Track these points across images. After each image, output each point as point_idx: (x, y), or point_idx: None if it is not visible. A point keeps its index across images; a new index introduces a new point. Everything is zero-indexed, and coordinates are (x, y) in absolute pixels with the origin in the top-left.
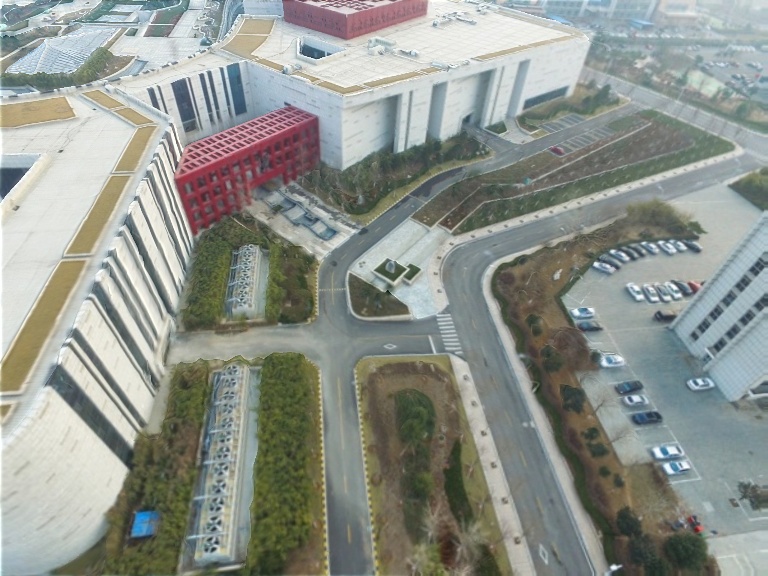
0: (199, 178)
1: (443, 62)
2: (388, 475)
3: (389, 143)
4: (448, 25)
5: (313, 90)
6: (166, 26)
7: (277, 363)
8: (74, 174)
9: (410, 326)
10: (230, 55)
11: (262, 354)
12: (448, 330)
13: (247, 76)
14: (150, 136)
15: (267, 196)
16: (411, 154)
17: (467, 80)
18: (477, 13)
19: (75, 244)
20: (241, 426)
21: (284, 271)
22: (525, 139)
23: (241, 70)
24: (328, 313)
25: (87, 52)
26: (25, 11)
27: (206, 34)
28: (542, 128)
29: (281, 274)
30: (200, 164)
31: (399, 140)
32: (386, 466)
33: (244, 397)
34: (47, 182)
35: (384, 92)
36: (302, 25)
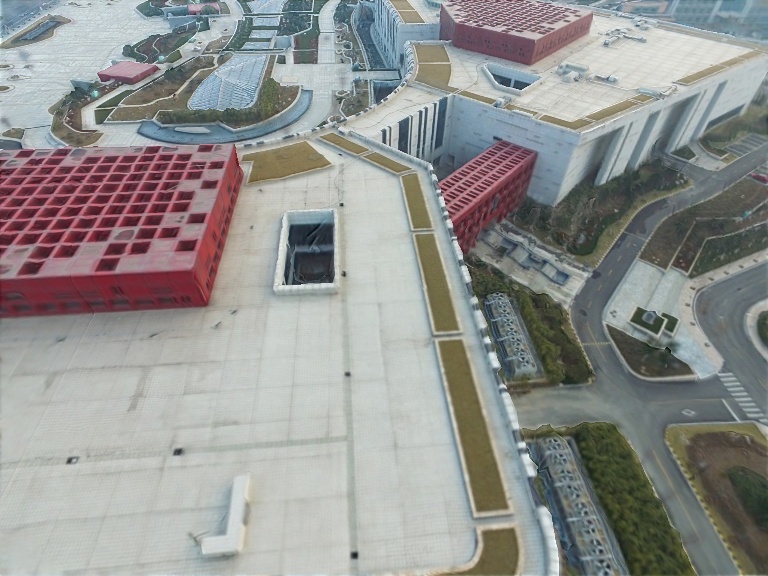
0: (454, 226)
1: (653, 89)
2: (767, 575)
3: (591, 175)
4: (620, 44)
5: (540, 126)
6: (310, 51)
7: (597, 436)
8: (373, 232)
9: (697, 388)
10: (428, 87)
11: (559, 420)
12: (739, 392)
13: (451, 109)
14: (420, 186)
15: (486, 236)
16: (614, 186)
17: (672, 106)
18: (637, 29)
19: (437, 319)
20: (597, 513)
21: (547, 324)
22: (718, 165)
23: (448, 104)
24: (605, 372)
25: (253, 83)
26: (170, 41)
27: (353, 59)
28: (730, 152)
29: (548, 328)
30: (455, 211)
31: (606, 172)
32: (759, 563)
33: (582, 477)
34: (353, 242)
35: (612, 126)
36: (475, 50)
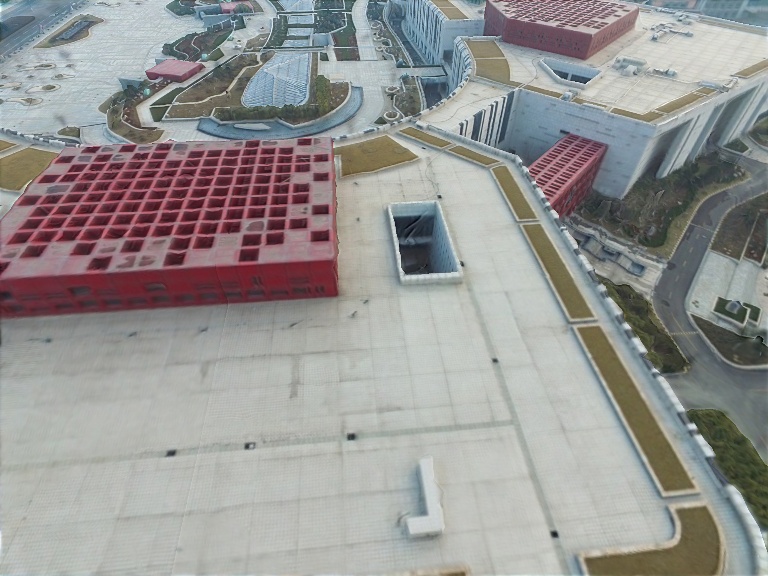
0: None
1: (715, 82)
2: None
3: (653, 168)
4: (668, 38)
5: (613, 119)
6: (350, 49)
7: (708, 422)
8: (479, 223)
9: None
10: (491, 82)
11: None
12: None
13: (516, 104)
14: (513, 177)
15: None
16: (676, 179)
17: (732, 99)
18: (680, 23)
19: (569, 306)
20: None
21: (636, 314)
22: None
23: (514, 98)
24: (698, 360)
25: (302, 80)
26: (208, 39)
27: (395, 56)
28: None
29: (639, 318)
30: None
31: (669, 165)
32: None
33: None
34: (461, 233)
35: (683, 118)
36: (526, 45)
